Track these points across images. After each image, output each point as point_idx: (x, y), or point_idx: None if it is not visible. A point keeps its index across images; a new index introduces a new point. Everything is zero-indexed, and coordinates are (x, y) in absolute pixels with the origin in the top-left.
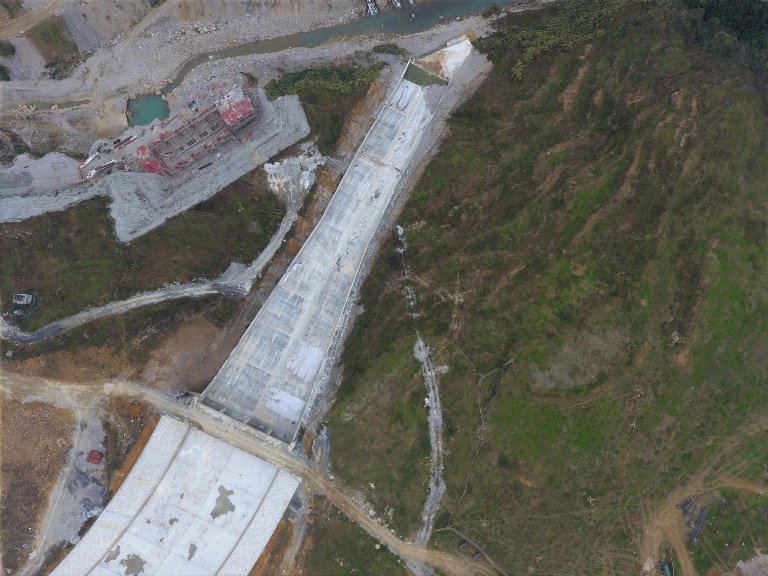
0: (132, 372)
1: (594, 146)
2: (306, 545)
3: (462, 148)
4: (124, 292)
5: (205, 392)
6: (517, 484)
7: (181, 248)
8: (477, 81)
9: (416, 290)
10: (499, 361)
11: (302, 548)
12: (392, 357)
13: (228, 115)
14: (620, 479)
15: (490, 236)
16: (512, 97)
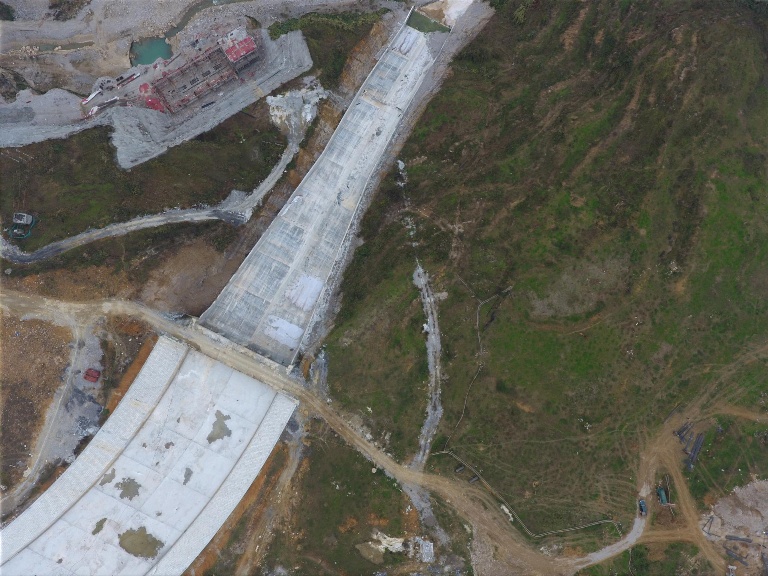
0: (131, 291)
1: (595, 83)
2: (302, 467)
3: (464, 87)
4: (124, 215)
5: (204, 316)
6: (514, 409)
7: (182, 175)
8: (479, 26)
9: (416, 220)
10: (498, 288)
11: (298, 470)
12: (391, 283)
13: (231, 52)
14: (617, 406)
15: (490, 170)
16: (514, 39)
